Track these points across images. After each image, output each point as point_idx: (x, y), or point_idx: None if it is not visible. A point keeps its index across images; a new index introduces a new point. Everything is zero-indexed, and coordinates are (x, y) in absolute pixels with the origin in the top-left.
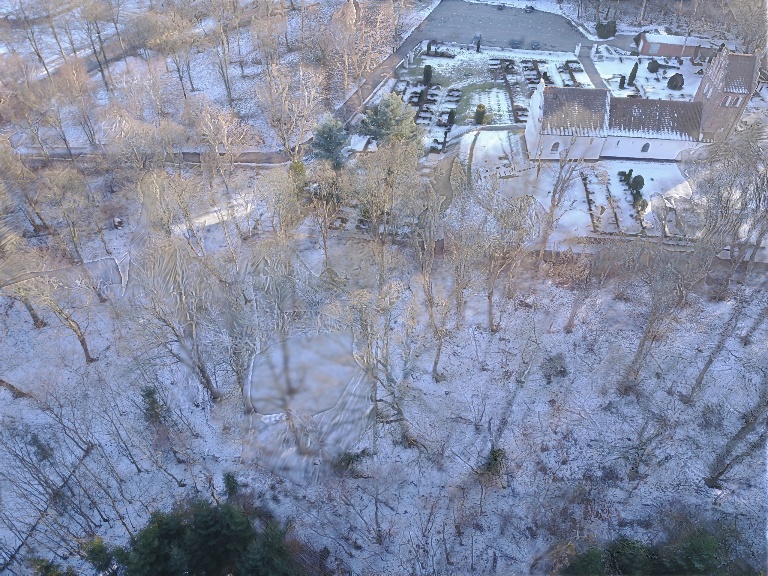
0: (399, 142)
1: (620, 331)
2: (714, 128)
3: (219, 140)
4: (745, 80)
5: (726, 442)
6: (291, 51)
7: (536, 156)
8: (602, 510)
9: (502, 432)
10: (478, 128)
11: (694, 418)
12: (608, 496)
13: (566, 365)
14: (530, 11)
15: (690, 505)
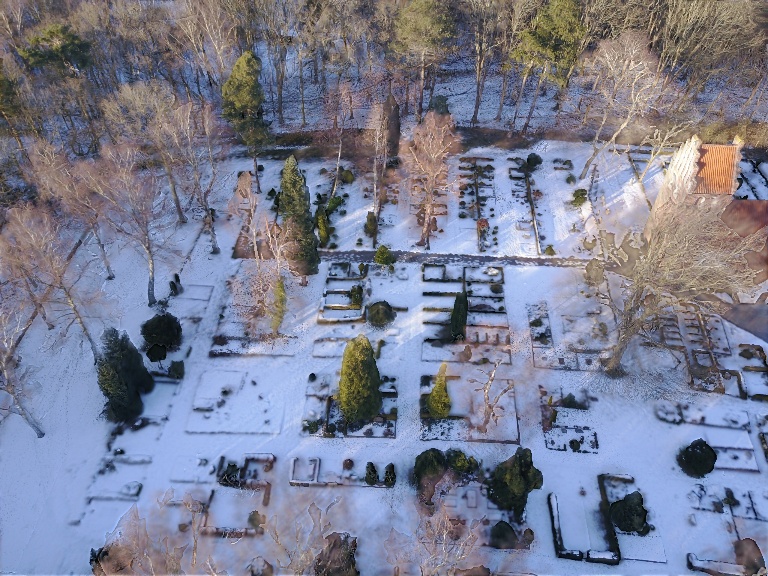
0: None
1: None
2: None
3: None
4: None
5: None
6: None
7: None
8: None
9: None
10: None
11: None
12: None
13: None
14: None
15: None
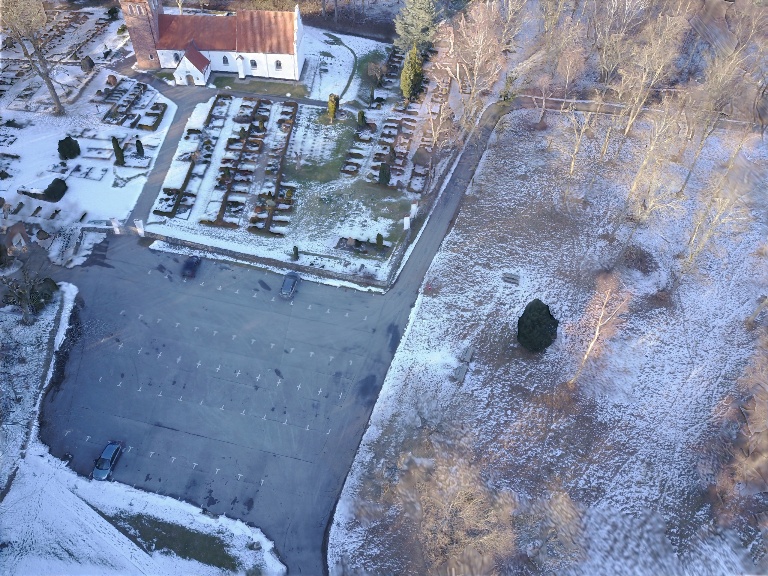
0: None
1: None
2: None
3: (543, 6)
4: None
5: None
6: (605, 270)
7: None
8: None
9: None
10: None
11: None
12: None
13: None
14: None
15: None
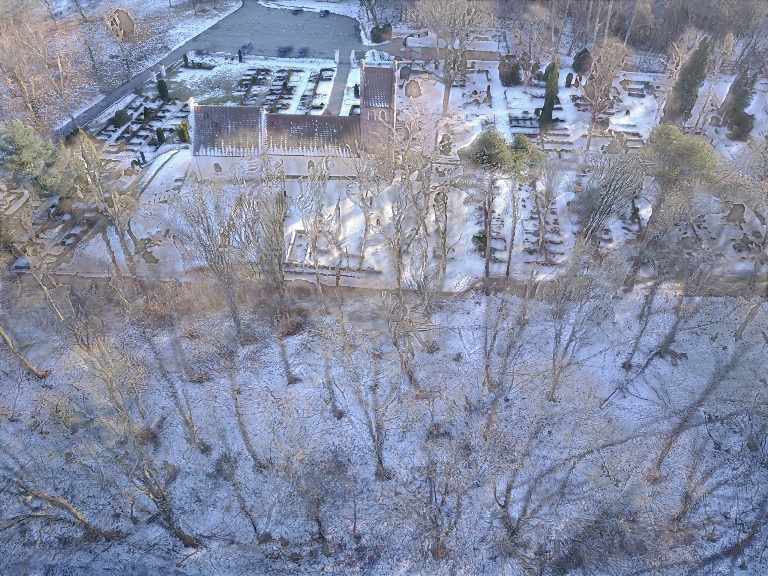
0: (23, 171)
1: (167, 373)
2: (373, 143)
3: None
4: (385, 93)
5: (230, 493)
6: (50, 67)
7: (202, 178)
8: (63, 575)
9: (2, 490)
10: (181, 147)
11: (206, 468)
12: (72, 560)
13: (96, 413)
14: (324, 15)
15: (154, 567)
